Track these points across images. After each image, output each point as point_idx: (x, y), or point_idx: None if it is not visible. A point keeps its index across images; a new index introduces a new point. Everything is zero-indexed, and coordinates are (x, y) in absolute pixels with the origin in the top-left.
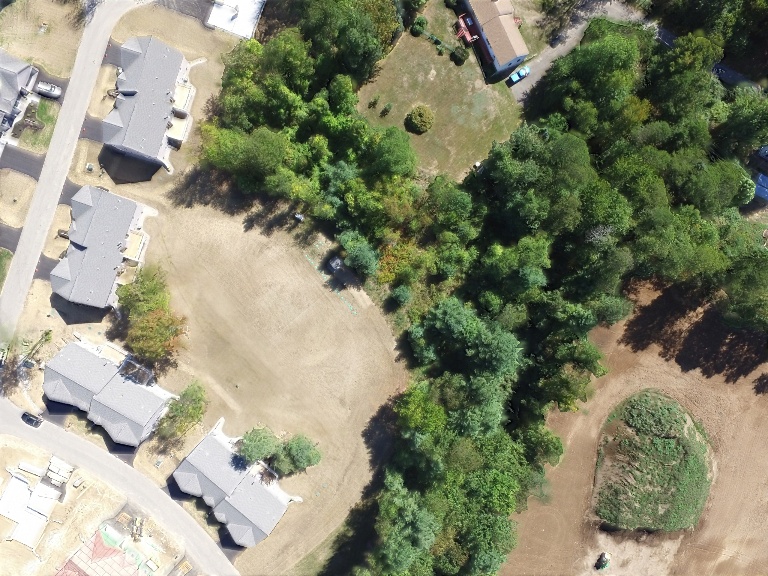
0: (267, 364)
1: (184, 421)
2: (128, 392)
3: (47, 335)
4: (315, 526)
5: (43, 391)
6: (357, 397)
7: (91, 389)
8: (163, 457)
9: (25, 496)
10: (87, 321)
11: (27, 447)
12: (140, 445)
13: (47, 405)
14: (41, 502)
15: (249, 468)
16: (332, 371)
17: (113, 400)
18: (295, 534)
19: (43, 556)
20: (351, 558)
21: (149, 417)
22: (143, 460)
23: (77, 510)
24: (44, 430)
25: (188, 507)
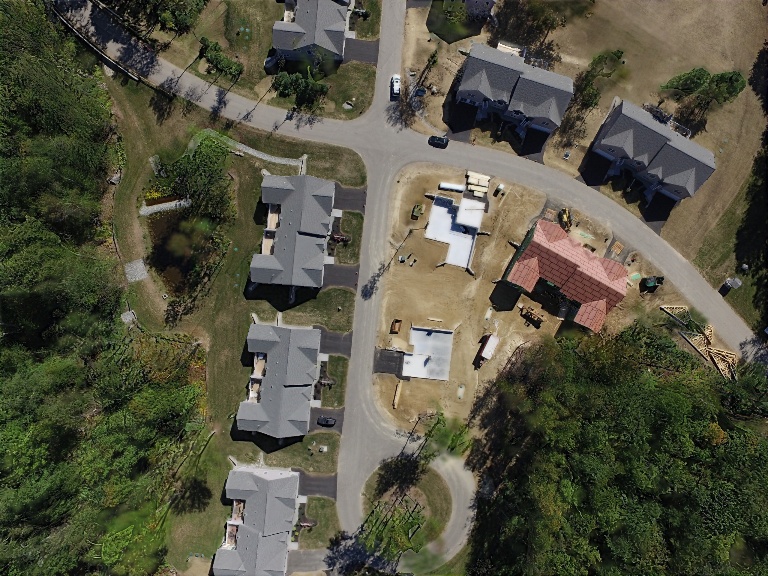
0: (650, 31)
1: (581, 109)
2: (542, 73)
3: (433, 58)
4: (725, 182)
5: (442, 113)
6: (736, 47)
7: (516, 69)
8: (569, 149)
9: (446, 220)
10: (467, 36)
11: (440, 170)
12: (545, 142)
13: (449, 125)
14: (469, 215)
15: (668, 123)
16: (709, 26)
17: (536, 78)
18: (709, 194)
19: (477, 273)
20: (766, 206)
21: (572, 88)
22: (551, 156)
23: (501, 219)
24: (452, 149)
25: (604, 190)
